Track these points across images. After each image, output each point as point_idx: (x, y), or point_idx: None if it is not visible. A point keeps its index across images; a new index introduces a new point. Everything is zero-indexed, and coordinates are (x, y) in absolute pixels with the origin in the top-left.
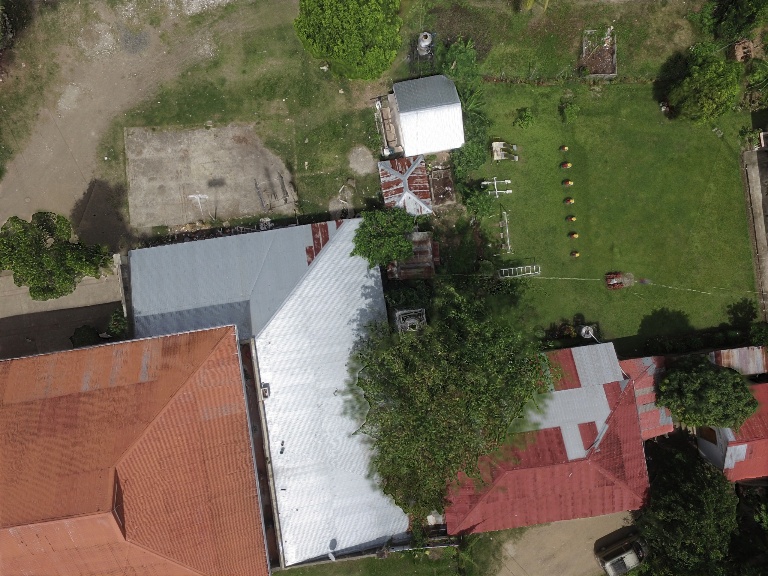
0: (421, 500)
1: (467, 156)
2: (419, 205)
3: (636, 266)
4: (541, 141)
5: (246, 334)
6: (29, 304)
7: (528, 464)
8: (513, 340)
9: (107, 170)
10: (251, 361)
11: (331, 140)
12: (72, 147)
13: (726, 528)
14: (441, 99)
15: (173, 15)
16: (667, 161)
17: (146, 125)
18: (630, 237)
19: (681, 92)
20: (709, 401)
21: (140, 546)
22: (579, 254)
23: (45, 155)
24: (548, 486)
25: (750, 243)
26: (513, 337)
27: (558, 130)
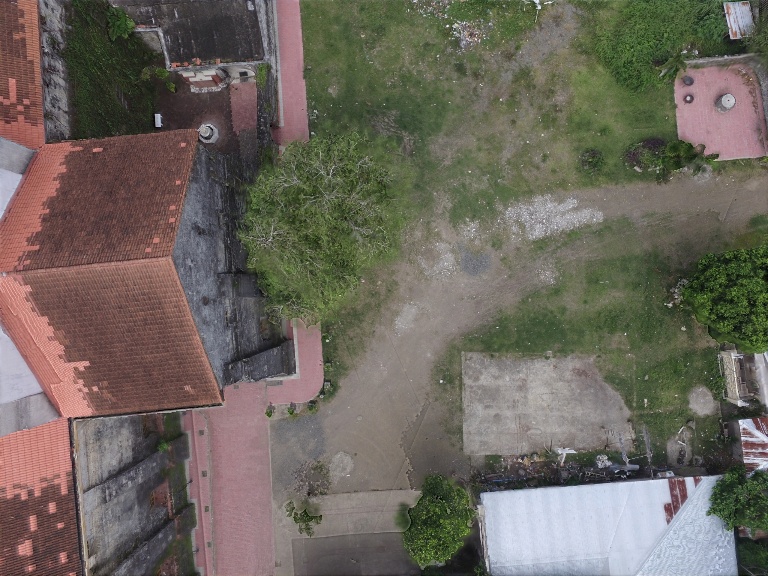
0: None
1: None
2: None
3: None
4: None
5: None
6: (355, 524)
7: None
8: None
9: (442, 393)
10: None
11: (672, 378)
12: (407, 367)
13: None
14: None
15: (515, 239)
16: None
17: (485, 351)
18: None
19: None
20: None
21: None
22: None
23: (380, 374)
24: None
25: None
26: None
27: None
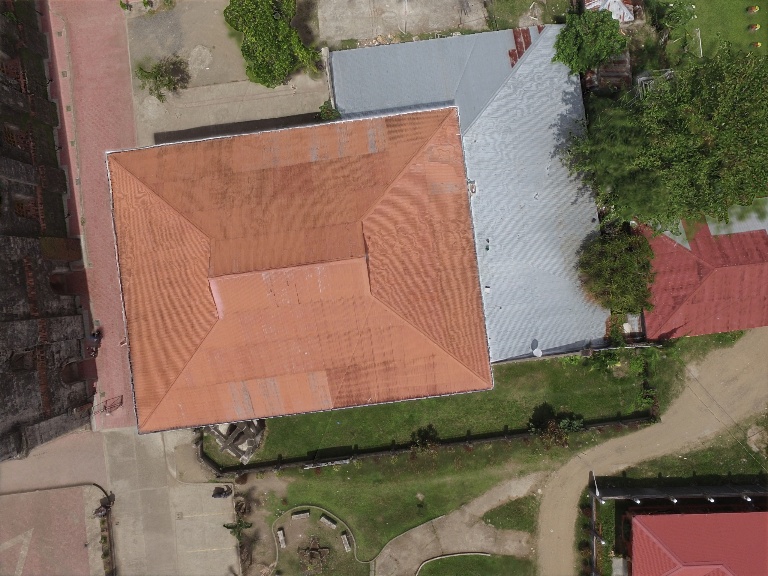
0: None
1: None
2: (622, 10)
3: None
4: None
5: None
6: (217, 115)
7: (737, 261)
8: None
9: None
10: None
11: None
12: None
13: None
14: None
15: None
16: None
17: None
18: None
19: None
20: None
21: (383, 303)
22: None
23: None
24: (755, 286)
25: None
26: None
27: None
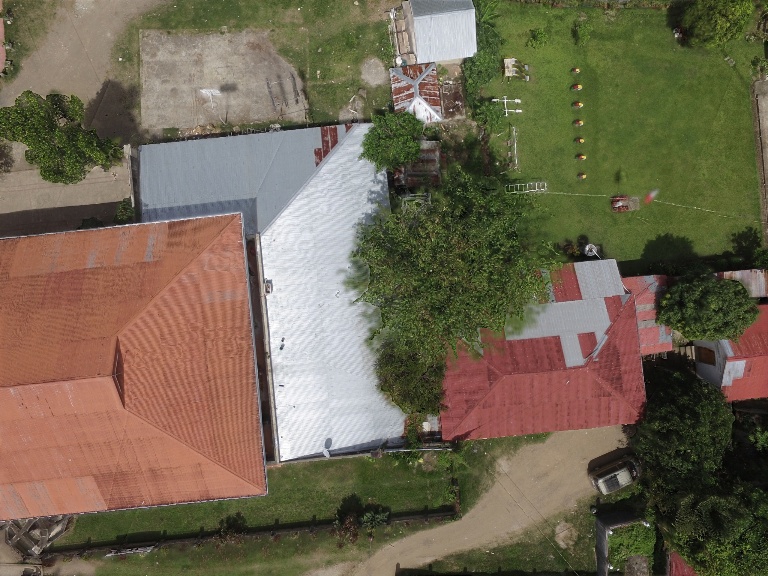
0: (418, 402)
1: (479, 66)
2: (429, 112)
3: (642, 191)
4: (553, 62)
5: (251, 230)
6: (38, 200)
7: (526, 369)
8: (517, 218)
9: (121, 71)
10: (255, 256)
11: (344, 50)
12: (87, 47)
13: (721, 441)
14: (455, 5)
15: None
16: (678, 88)
17: (161, 28)
18: (637, 162)
19: (695, 11)
20: (710, 307)
21: (138, 416)
22: (586, 176)
23: (61, 54)
24: (545, 393)
25: (757, 173)
26: (517, 214)
27: (570, 52)
